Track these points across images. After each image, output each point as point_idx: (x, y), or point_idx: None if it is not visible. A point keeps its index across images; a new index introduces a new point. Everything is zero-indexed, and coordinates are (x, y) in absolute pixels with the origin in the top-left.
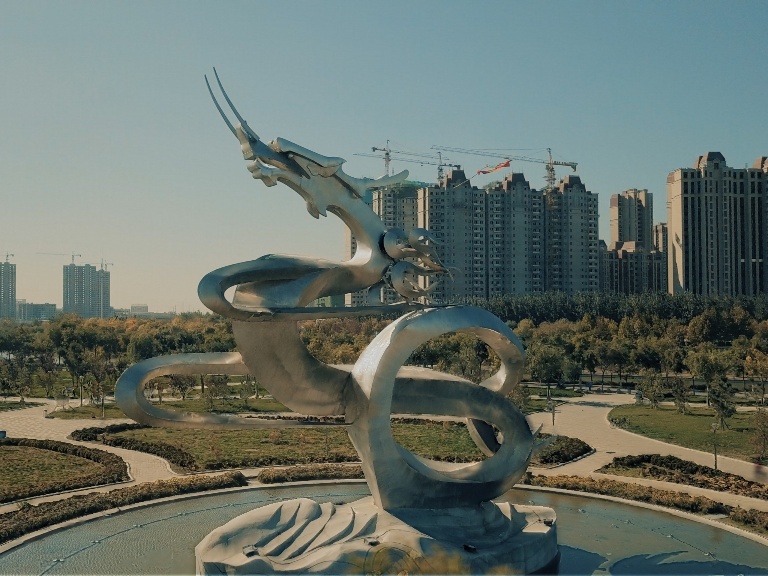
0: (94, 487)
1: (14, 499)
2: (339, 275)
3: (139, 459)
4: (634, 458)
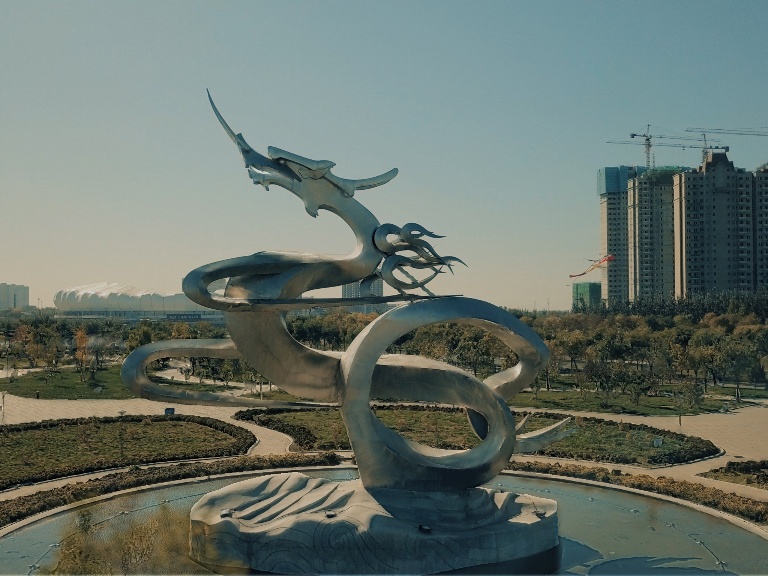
0: (211, 458)
1: (139, 463)
2: (326, 269)
3: (272, 438)
4: (752, 463)
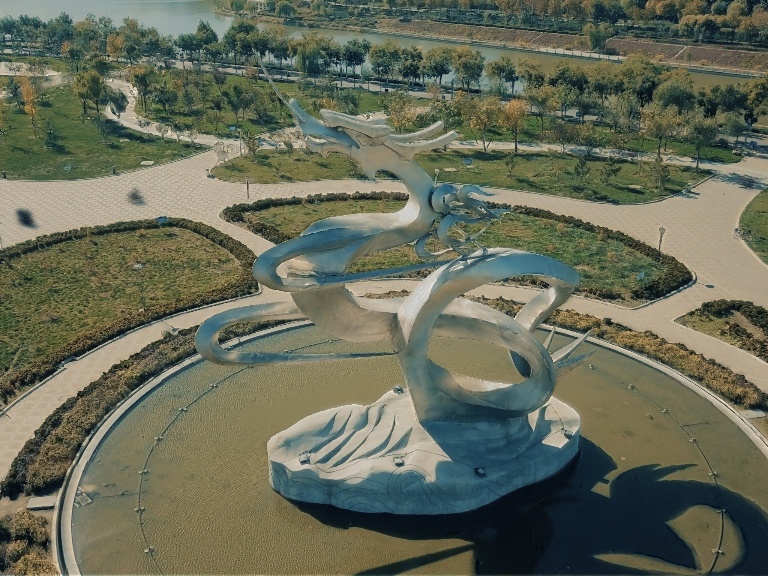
0: (227, 301)
1: (163, 316)
2: (385, 236)
3: None
4: (724, 305)
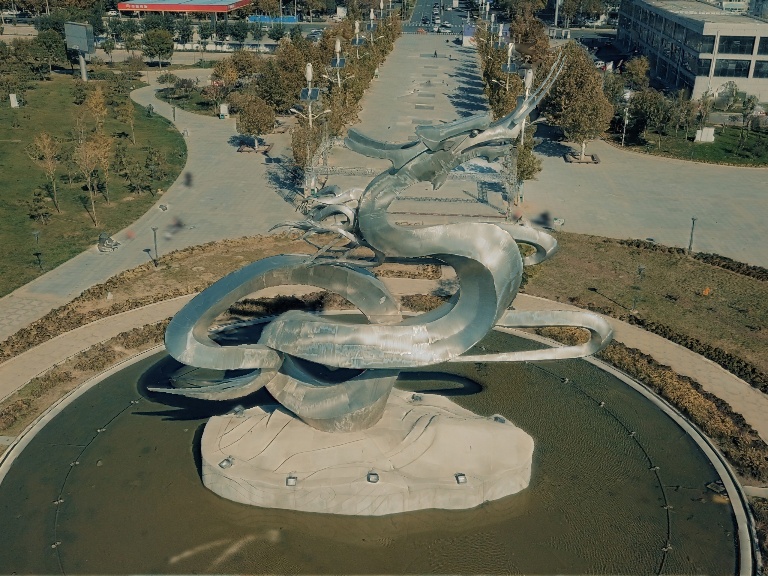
0: None
1: None
2: None
3: None
4: None
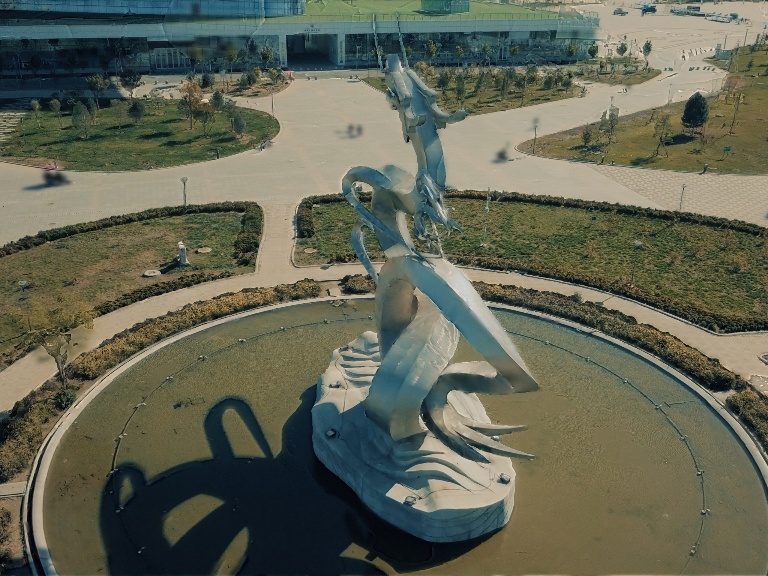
0: (682, 320)
1: (621, 294)
2: None
3: None
4: None
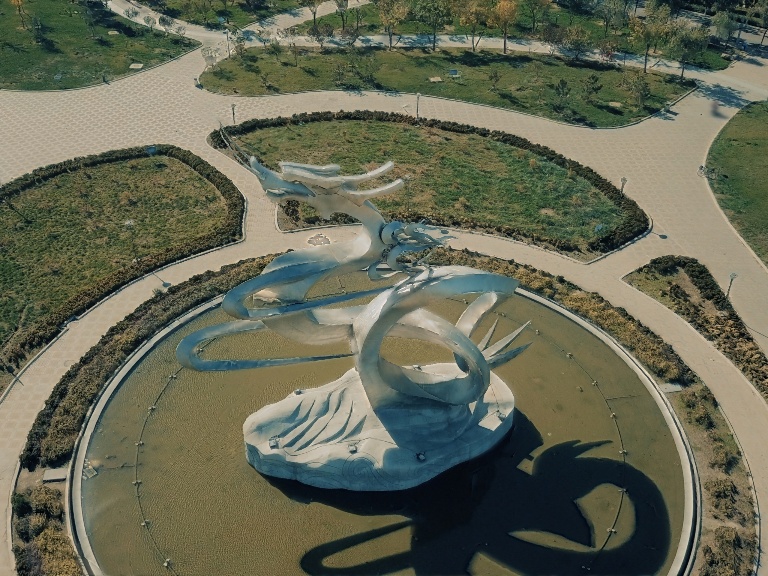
0: (213, 250)
1: (154, 269)
2: (340, 268)
3: (257, 193)
4: (670, 262)
